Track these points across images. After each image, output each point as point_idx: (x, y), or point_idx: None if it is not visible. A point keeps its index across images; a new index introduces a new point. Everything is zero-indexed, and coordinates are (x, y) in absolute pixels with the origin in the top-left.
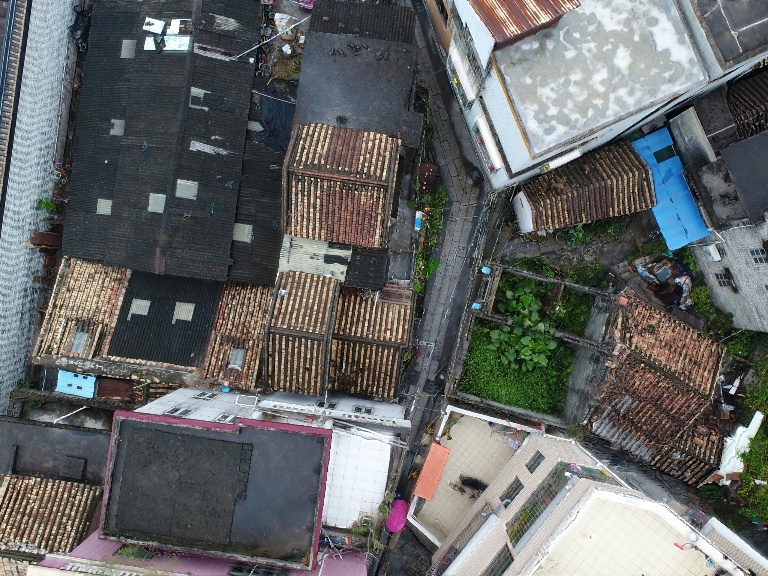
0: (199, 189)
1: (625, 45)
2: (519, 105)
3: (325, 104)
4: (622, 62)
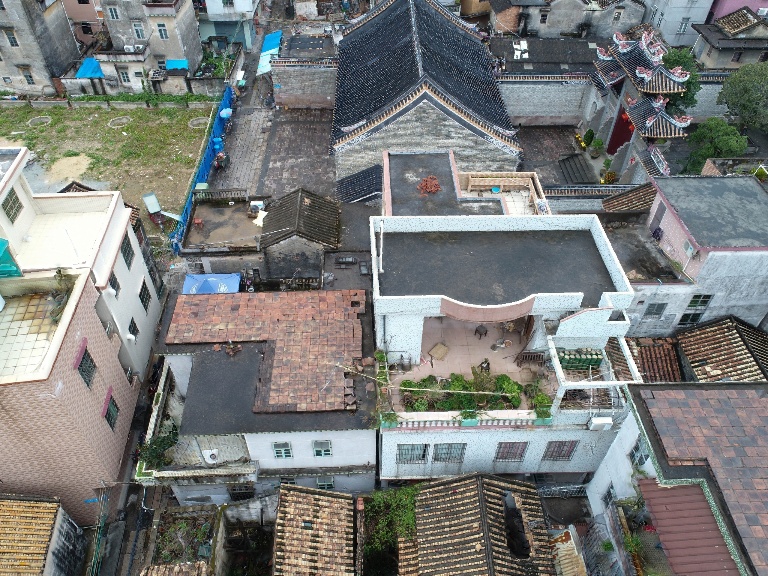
0: None
1: None
2: None
3: (537, 1)
4: None
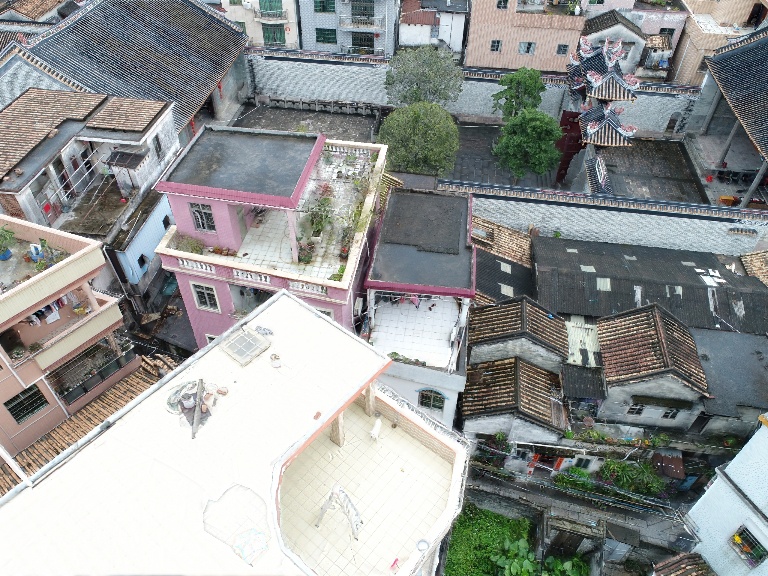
0: (606, 292)
1: None
2: None
3: (713, 347)
4: None
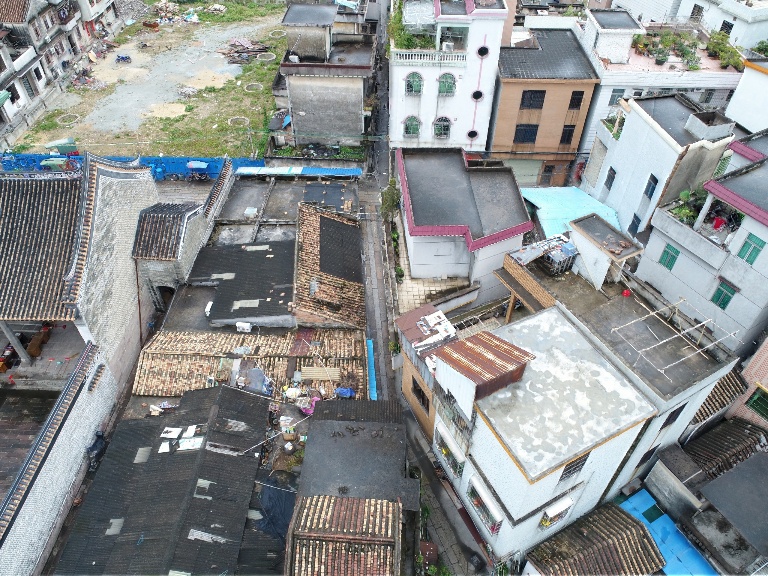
0: None
1: (580, 390)
2: (507, 439)
3: (327, 477)
4: (582, 402)
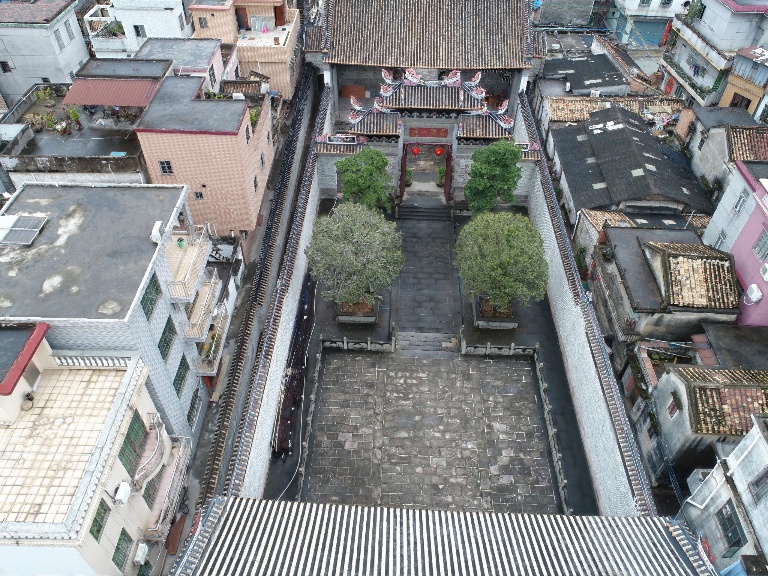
0: (656, 169)
1: None
2: None
3: (717, 123)
4: None
